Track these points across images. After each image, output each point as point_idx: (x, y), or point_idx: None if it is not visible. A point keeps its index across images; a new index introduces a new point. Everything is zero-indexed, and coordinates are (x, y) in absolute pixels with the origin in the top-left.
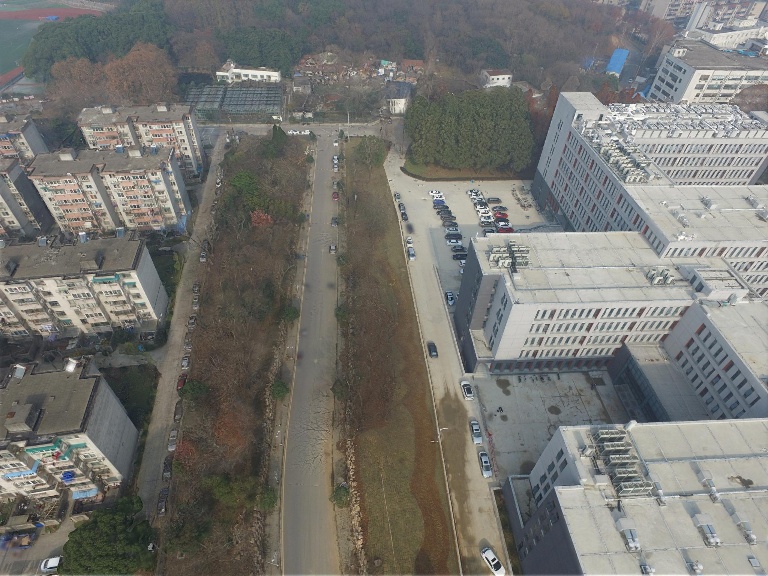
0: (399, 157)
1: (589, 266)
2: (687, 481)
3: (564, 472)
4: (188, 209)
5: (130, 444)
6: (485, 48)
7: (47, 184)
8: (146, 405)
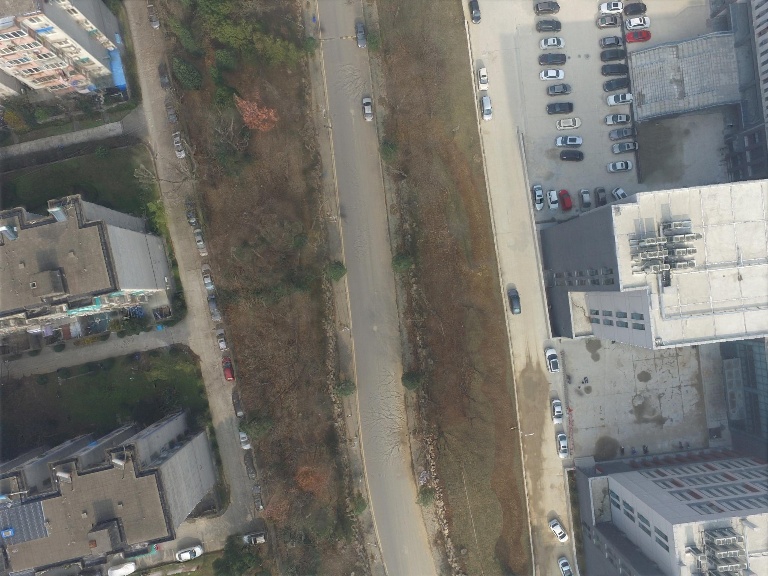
0: None
1: None
2: None
3: (661, 549)
4: (113, 31)
5: (204, 453)
6: None
7: None
8: (199, 399)
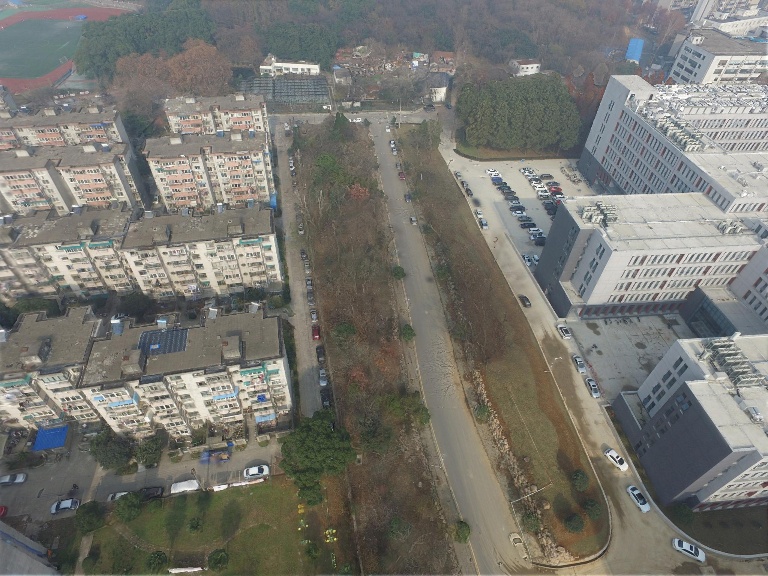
0: (450, 141)
1: (667, 221)
2: None
3: (684, 375)
4: None
5: None
6: (513, 39)
7: (163, 165)
8: None
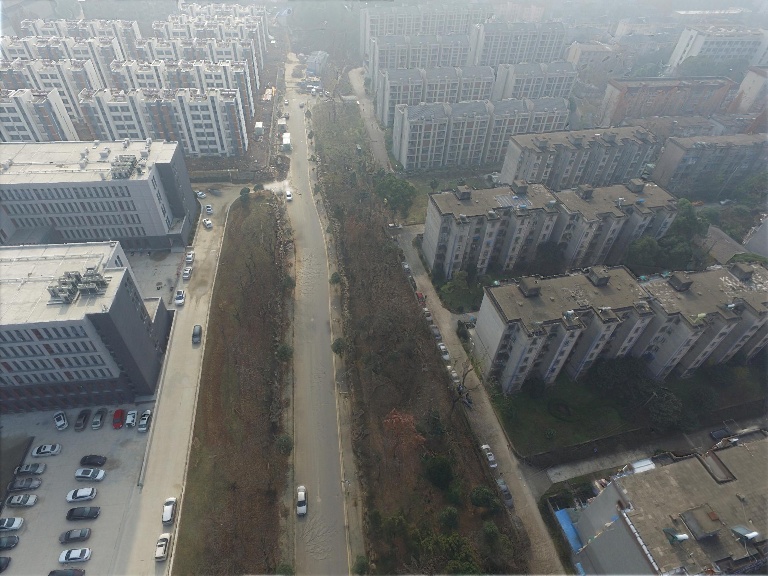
0: None
1: None
2: (94, 166)
3: None
4: None
5: None
6: None
7: None
8: None
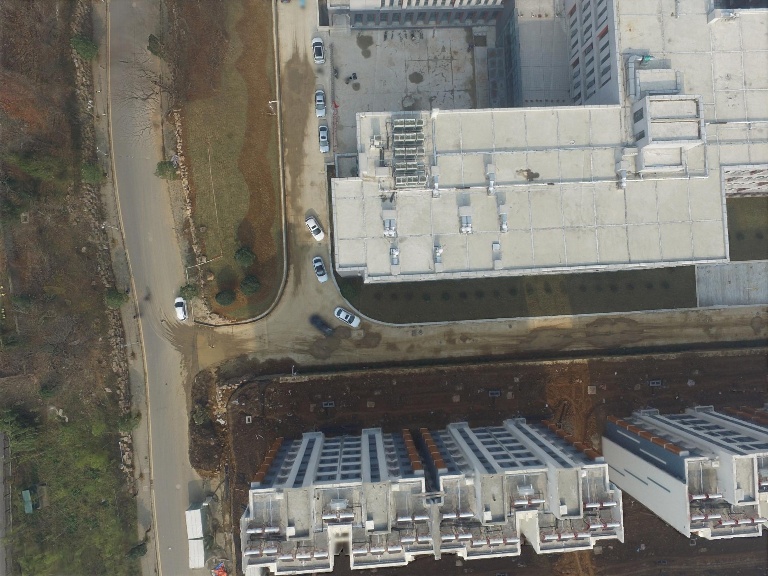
0: None
1: None
2: (472, 174)
3: None
4: None
5: None
6: None
7: None
8: None
